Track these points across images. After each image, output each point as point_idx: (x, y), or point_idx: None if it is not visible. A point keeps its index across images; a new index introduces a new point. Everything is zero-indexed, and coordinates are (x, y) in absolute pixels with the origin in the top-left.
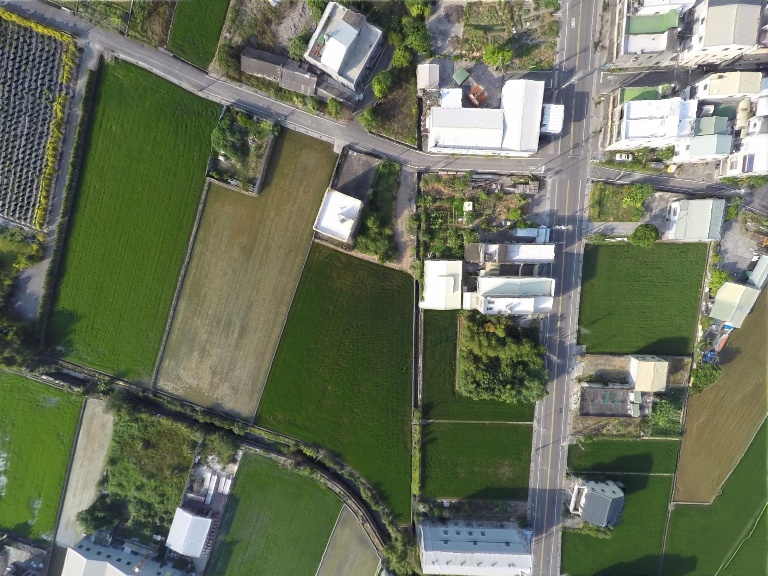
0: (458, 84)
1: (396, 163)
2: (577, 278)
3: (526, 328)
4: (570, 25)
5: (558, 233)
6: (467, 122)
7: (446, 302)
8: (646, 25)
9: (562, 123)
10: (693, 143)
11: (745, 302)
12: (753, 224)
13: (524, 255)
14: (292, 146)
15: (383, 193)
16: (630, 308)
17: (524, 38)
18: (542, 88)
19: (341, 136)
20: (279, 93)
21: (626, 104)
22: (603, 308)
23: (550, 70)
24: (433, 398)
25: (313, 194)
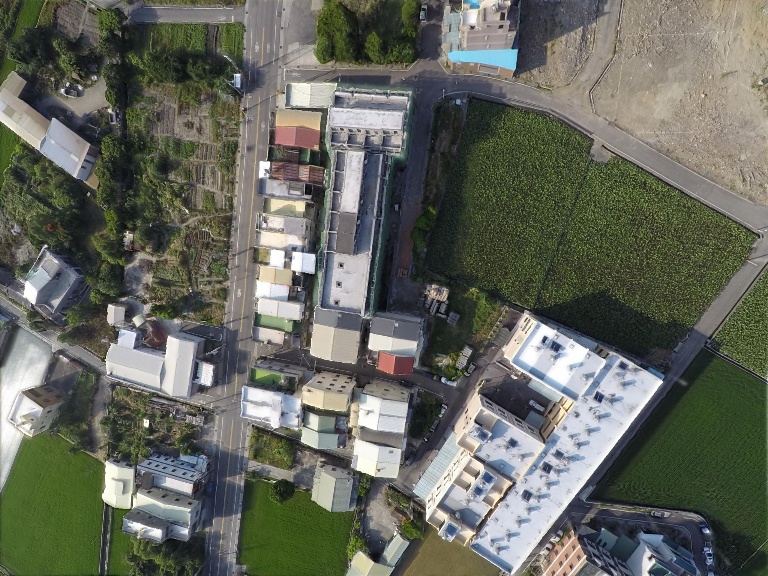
0: (136, 327)
1: (93, 374)
2: (238, 505)
3: (192, 537)
4: (236, 294)
5: (223, 462)
6: (133, 363)
7: (117, 501)
8: (273, 320)
9: (211, 380)
10: (303, 432)
11: (376, 575)
12: (393, 502)
13: (170, 484)
14: (23, 340)
15: (81, 395)
16: (284, 545)
17: (199, 297)
18: (192, 350)
19: (56, 341)
20: (13, 300)
21: (243, 387)
22: (261, 537)
23: (219, 327)
24: (118, 572)
25: (35, 380)
